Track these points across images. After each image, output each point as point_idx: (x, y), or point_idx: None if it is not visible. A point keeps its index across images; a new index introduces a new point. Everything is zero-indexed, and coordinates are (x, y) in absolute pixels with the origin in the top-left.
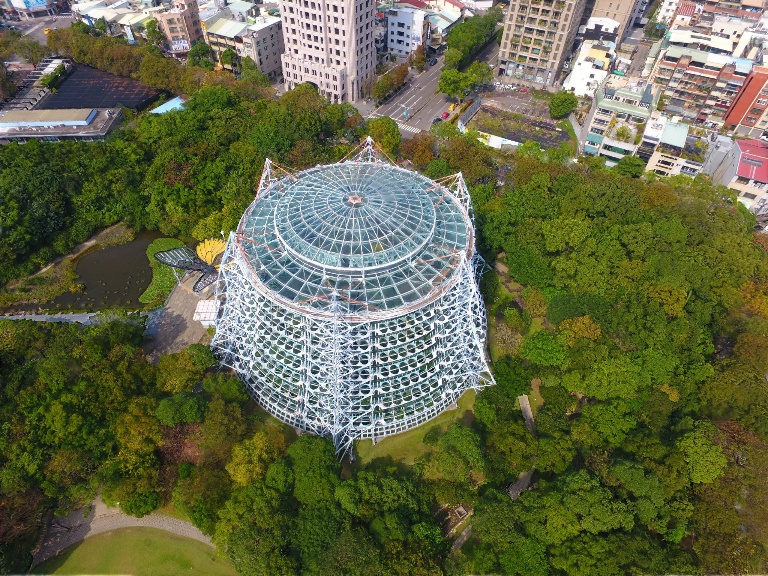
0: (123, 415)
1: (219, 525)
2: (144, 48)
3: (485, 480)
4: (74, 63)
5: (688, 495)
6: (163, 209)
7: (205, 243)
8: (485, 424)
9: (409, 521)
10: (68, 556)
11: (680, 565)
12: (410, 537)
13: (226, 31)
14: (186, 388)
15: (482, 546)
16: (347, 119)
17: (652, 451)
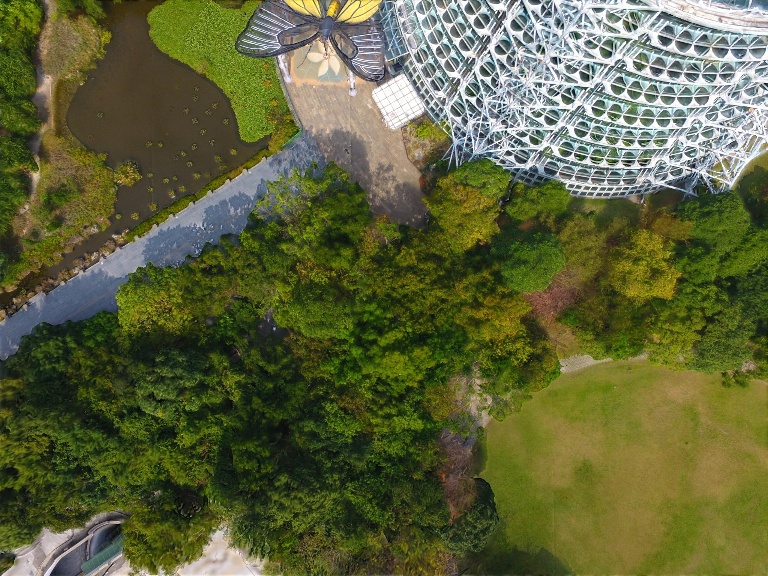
0: (462, 311)
1: (661, 348)
2: None
3: None
4: None
5: None
6: None
7: None
8: None
9: None
10: (485, 449)
11: None
12: None
13: None
14: (489, 231)
15: None
16: None
17: None
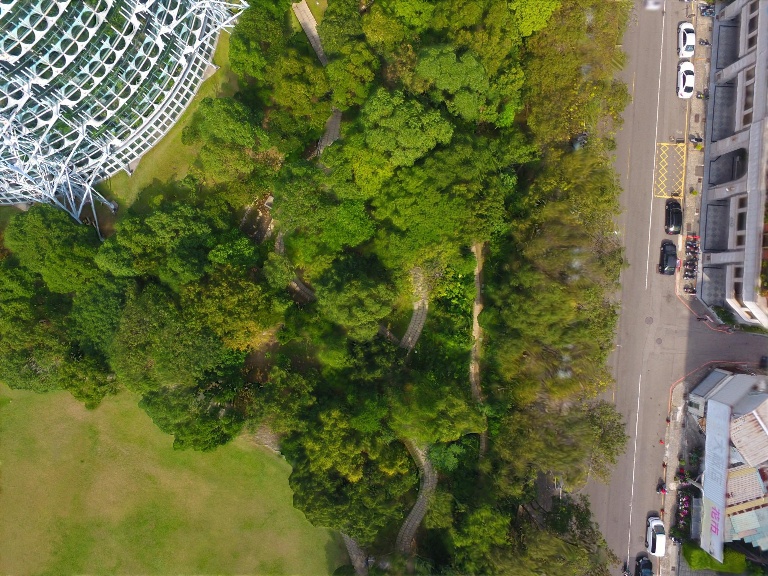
0: None
1: None
2: None
3: None
4: None
5: (520, 57)
6: None
7: None
8: (254, 78)
9: (204, 250)
10: None
11: (513, 151)
12: (208, 269)
13: None
14: None
15: (301, 232)
16: None
17: (465, 16)
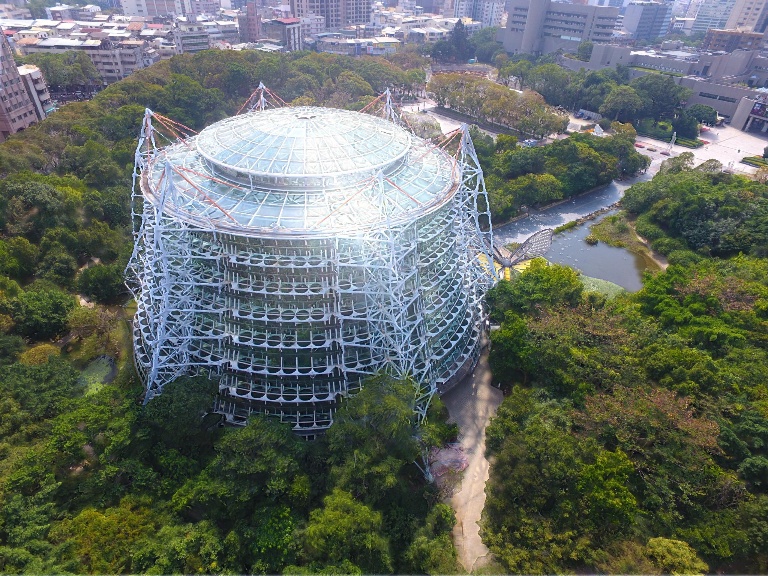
0: None
1: None
2: None
3: None
4: None
5: None
6: None
7: None
8: None
9: None
10: None
11: None
12: None
13: None
14: None
15: None
16: None
17: None
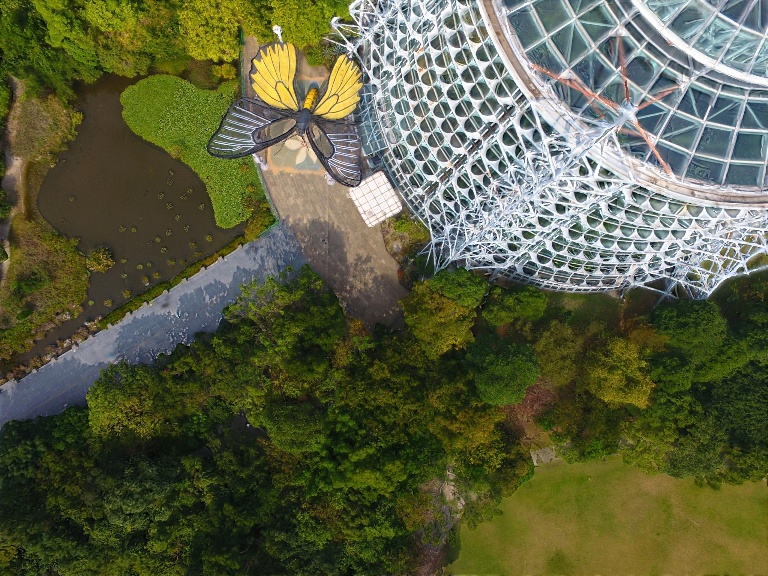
0: (435, 421)
1: (634, 453)
2: None
3: None
4: None
5: None
6: (86, 26)
7: (259, 70)
8: None
9: None
10: (459, 539)
11: None
12: None
13: None
14: None
15: None
16: None
17: None
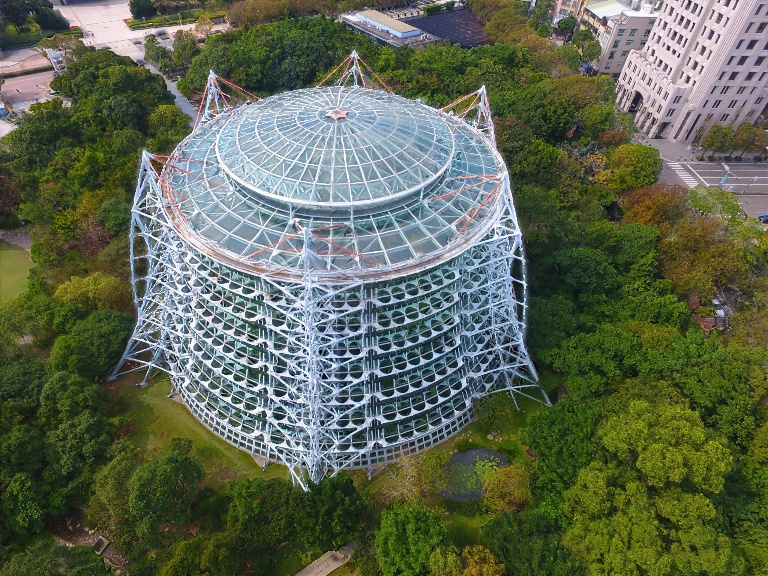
0: None
1: None
2: (512, 1)
3: (153, 557)
4: (467, 6)
5: None
6: None
7: None
8: (229, 509)
9: (39, 469)
10: (10, 249)
11: None
12: (2, 474)
13: (602, 11)
14: None
15: None
16: (605, 130)
17: None
